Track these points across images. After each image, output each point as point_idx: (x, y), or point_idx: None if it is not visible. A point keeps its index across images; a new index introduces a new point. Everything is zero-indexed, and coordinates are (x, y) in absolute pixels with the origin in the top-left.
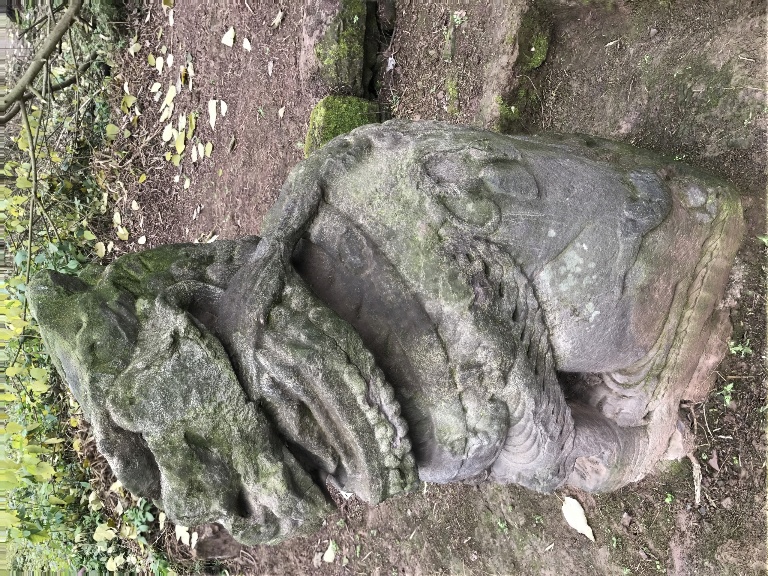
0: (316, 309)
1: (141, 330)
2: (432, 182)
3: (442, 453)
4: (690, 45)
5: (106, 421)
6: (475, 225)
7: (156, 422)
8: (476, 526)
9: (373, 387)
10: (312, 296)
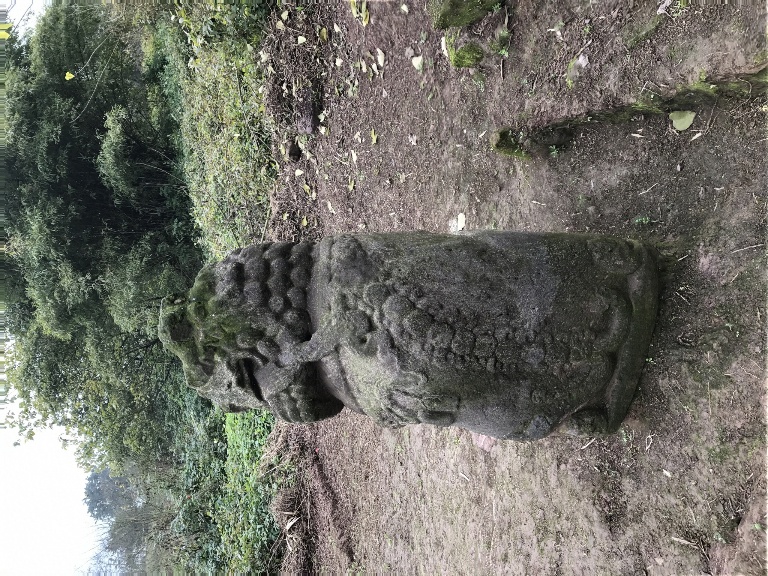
0: (302, 403)
1: (215, 368)
2: (389, 403)
3: None
4: (767, 322)
5: None
6: (403, 419)
7: None
8: (486, 202)
9: None
10: (306, 389)
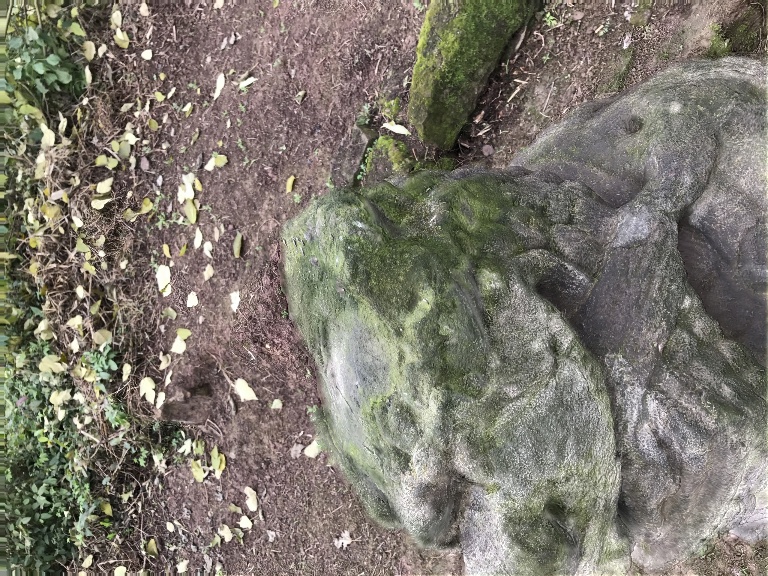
0: (733, 345)
1: (488, 324)
2: None
3: None
4: None
5: (438, 467)
6: None
7: (517, 486)
8: None
9: (765, 465)
10: None
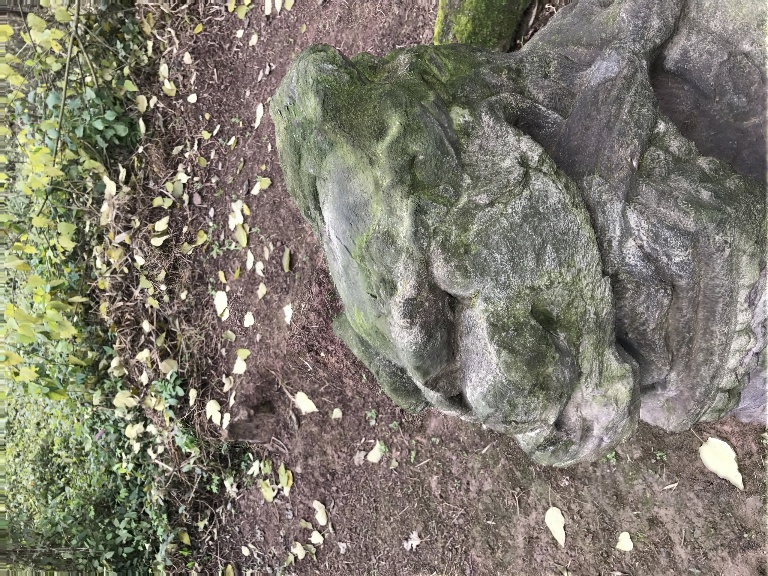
0: (709, 158)
1: (464, 151)
2: None
3: (752, 379)
4: None
5: (425, 273)
6: None
7: (501, 284)
8: None
9: (763, 280)
10: None
